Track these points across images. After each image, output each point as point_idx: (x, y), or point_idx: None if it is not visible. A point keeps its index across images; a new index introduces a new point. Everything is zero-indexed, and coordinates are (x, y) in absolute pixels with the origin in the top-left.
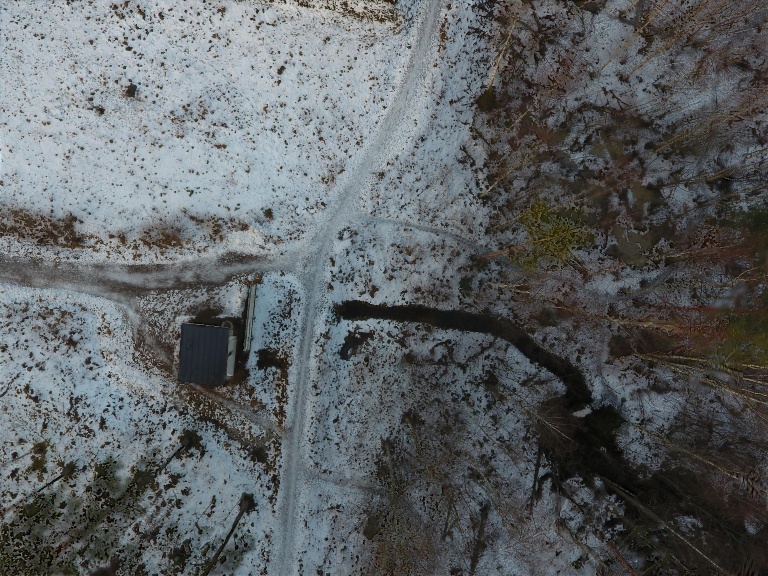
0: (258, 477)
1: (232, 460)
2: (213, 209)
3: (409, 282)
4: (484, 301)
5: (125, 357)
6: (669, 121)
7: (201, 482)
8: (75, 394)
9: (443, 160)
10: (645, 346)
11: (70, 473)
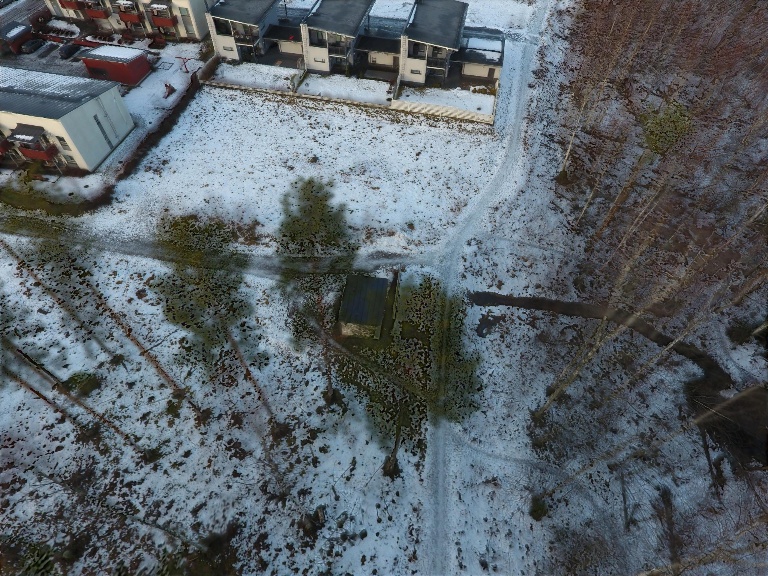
0: (402, 441)
1: (374, 422)
2: (368, 222)
3: (529, 280)
4: (598, 296)
5: (278, 322)
6: (699, 193)
7: (341, 441)
8: (226, 348)
9: (539, 206)
10: (761, 334)
11: (205, 418)
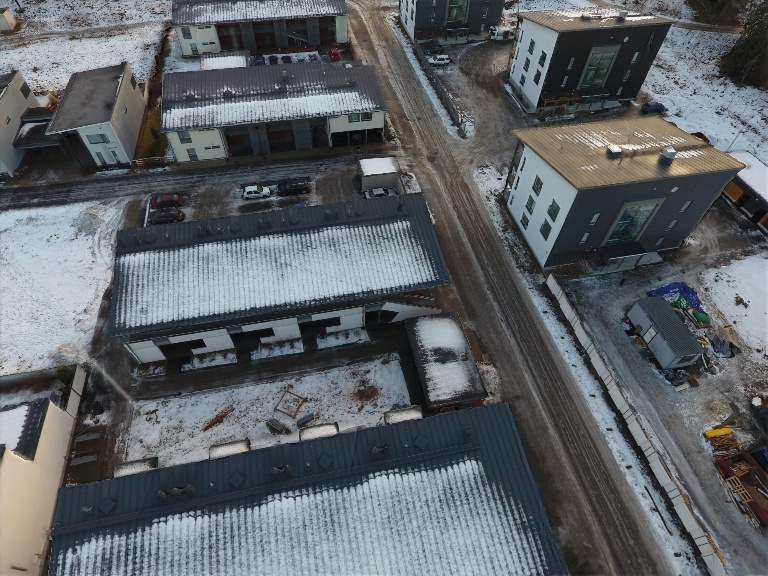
0: None
1: None
2: None
3: None
4: None
5: None
6: None
7: (17, 5)
8: None
9: None
10: None
11: None
